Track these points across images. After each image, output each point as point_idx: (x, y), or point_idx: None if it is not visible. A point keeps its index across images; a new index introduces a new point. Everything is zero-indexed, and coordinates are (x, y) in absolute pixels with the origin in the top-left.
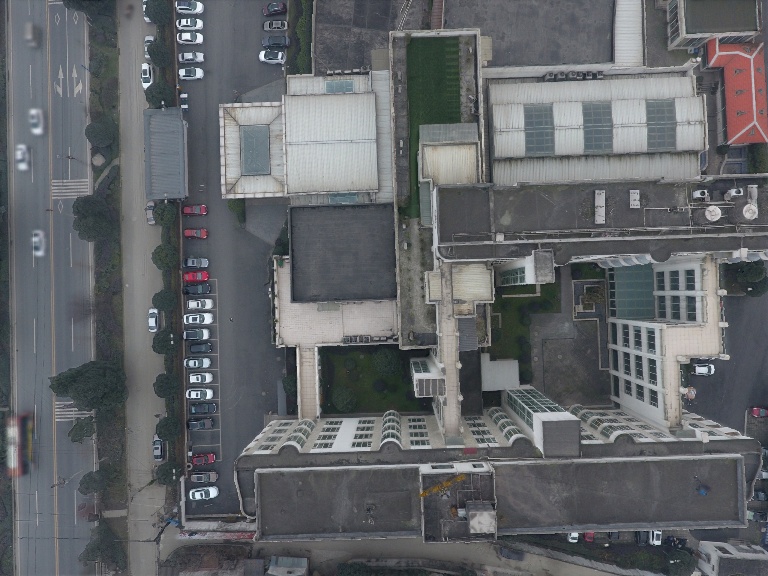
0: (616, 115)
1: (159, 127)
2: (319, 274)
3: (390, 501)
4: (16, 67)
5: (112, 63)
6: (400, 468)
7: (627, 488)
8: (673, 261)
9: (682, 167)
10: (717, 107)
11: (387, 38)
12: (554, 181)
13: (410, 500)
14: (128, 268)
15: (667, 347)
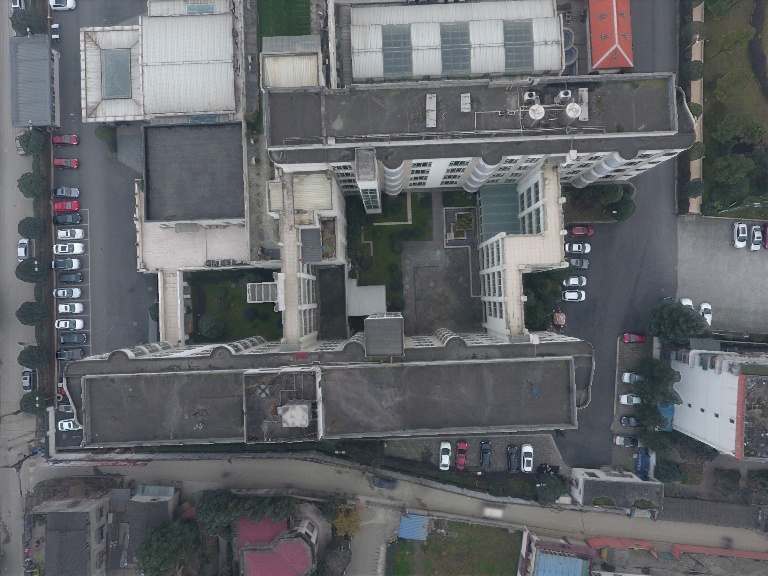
0: (474, 35)
1: (26, 55)
2: (175, 194)
3: (221, 407)
4: None
5: None
6: (228, 372)
7: (460, 392)
8: (527, 178)
9: None
10: (587, 35)
11: None
12: (383, 84)
13: (242, 406)
14: None
15: (509, 256)
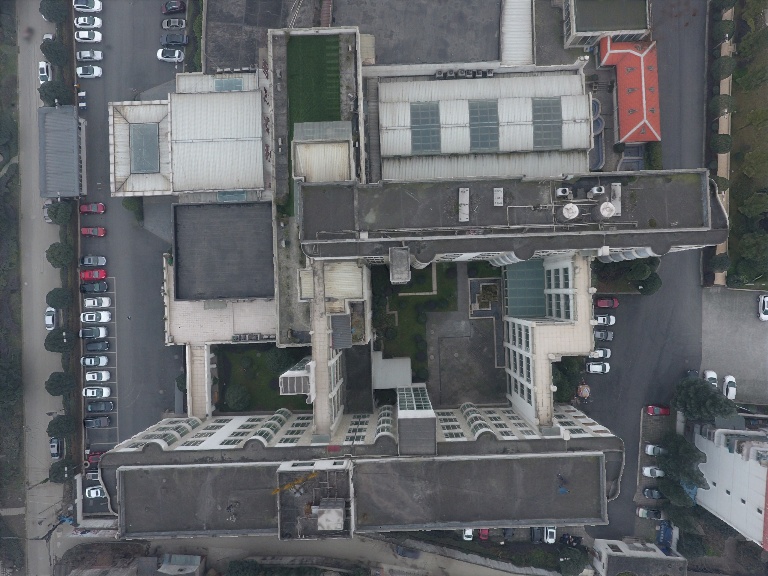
0: (502, 113)
1: (54, 125)
2: (204, 272)
3: (254, 499)
4: None
5: (11, 61)
6: (261, 466)
7: (490, 486)
8: (555, 259)
9: (571, 165)
10: (613, 105)
11: None
12: (416, 179)
13: (274, 498)
14: (27, 266)
15: (539, 345)
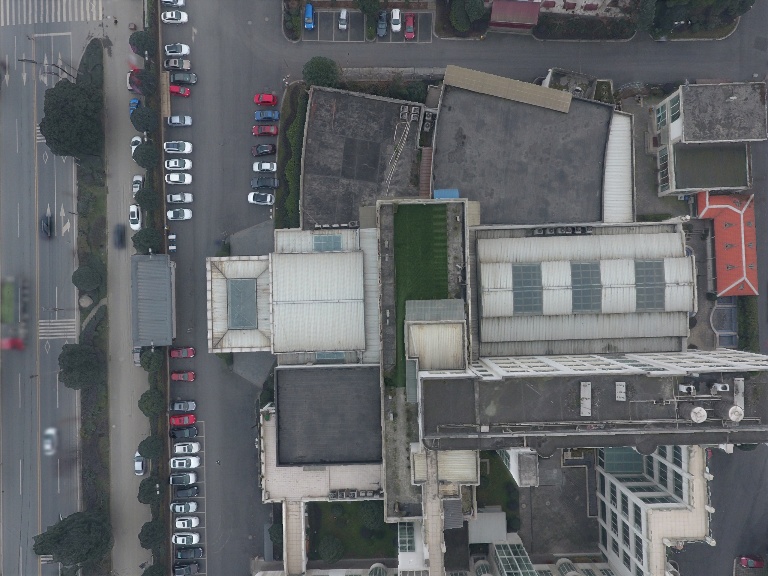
0: (605, 275)
1: (146, 273)
2: (305, 435)
3: None
4: (4, 205)
5: (100, 202)
6: None
7: None
8: None
9: (671, 324)
10: (707, 253)
11: (376, 189)
12: (539, 375)
13: None
14: (115, 409)
15: (653, 529)
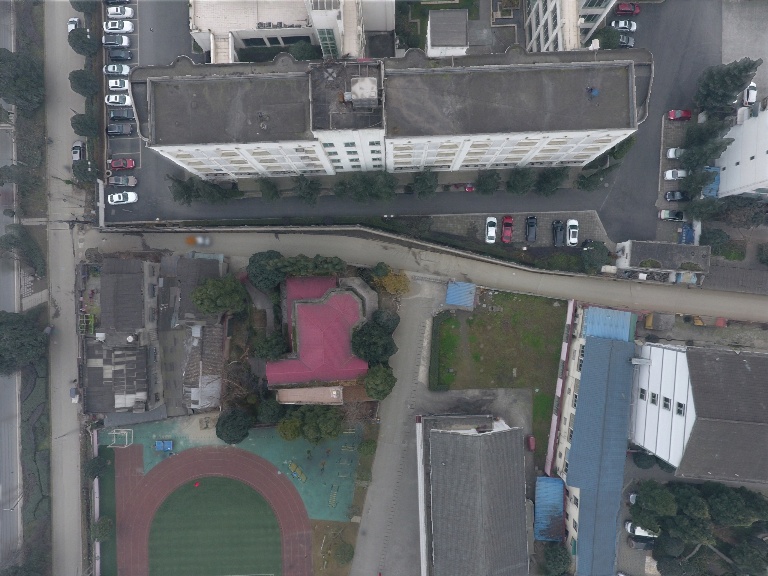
0: None
1: None
2: None
3: (284, 113)
4: None
5: None
6: (292, 73)
7: (520, 100)
8: None
9: None
10: None
11: None
12: None
13: (304, 112)
14: None
15: None
